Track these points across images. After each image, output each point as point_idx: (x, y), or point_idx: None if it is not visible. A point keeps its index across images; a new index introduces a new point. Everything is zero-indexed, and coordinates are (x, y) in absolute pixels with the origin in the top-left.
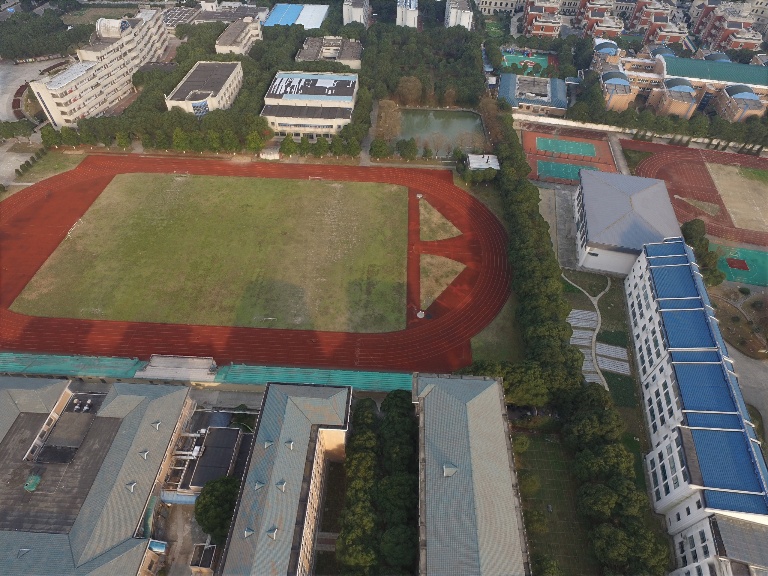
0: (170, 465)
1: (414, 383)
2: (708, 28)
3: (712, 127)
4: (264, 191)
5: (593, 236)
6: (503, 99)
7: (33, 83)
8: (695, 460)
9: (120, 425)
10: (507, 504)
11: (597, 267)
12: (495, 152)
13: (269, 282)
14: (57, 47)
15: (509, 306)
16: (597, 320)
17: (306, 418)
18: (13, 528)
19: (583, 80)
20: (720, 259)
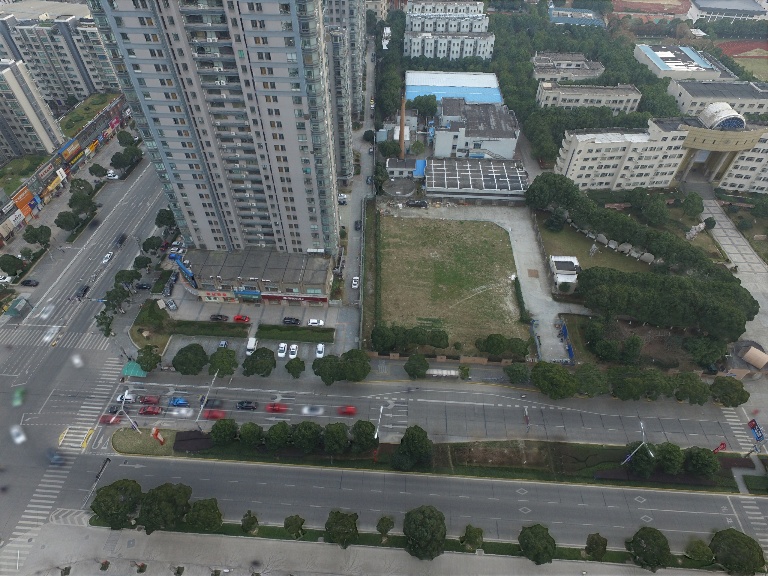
0: None
1: None
2: None
3: None
4: None
5: (763, 10)
6: None
7: None
8: None
9: None
10: None
11: None
12: None
13: None
14: None
15: None
16: None
17: None
18: None
19: (560, 1)
20: None
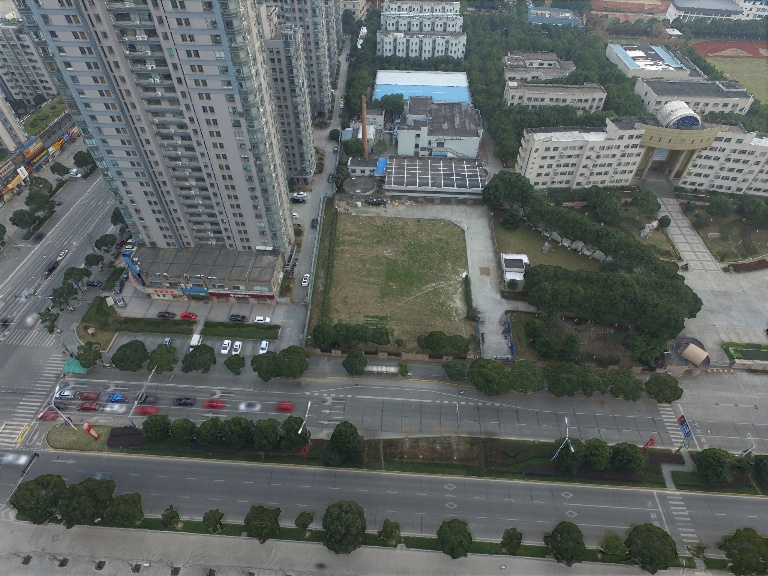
0: None
1: None
2: None
3: None
4: (763, 95)
5: (739, 9)
6: (593, 17)
7: None
8: None
9: None
10: None
11: None
12: None
13: None
14: None
15: None
16: None
17: None
18: None
19: (539, 0)
20: None
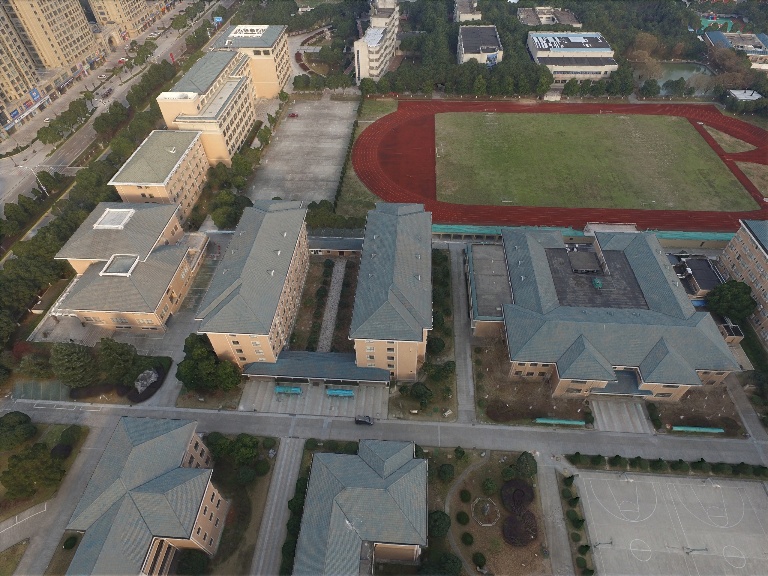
0: None
1: None
2: None
3: None
4: (567, 122)
5: None
6: (733, 49)
7: (357, 42)
8: None
9: (625, 254)
10: None
11: None
12: (754, 87)
13: (626, 181)
14: (309, 23)
15: None
16: None
17: None
18: (606, 307)
19: None
20: None
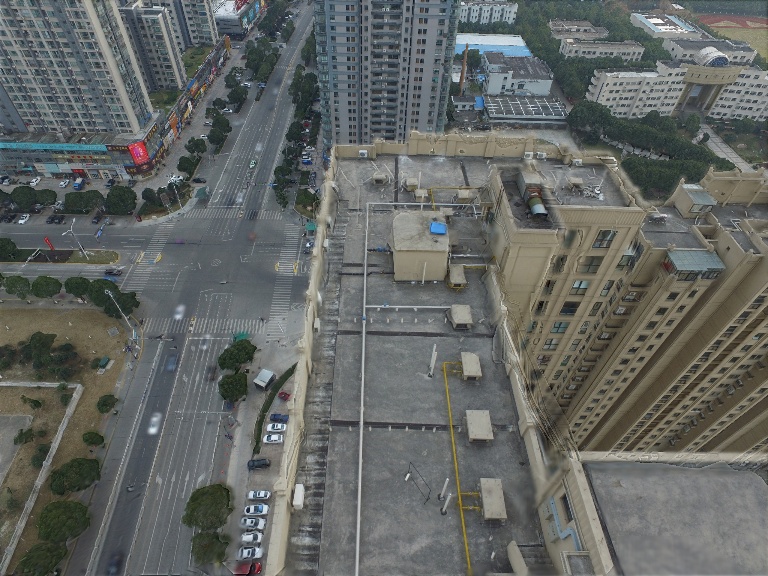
0: None
1: None
2: None
3: None
4: None
5: None
6: None
7: None
8: None
9: None
10: None
11: None
12: None
13: None
14: None
15: (759, 17)
16: None
17: None
18: None
19: None
20: None
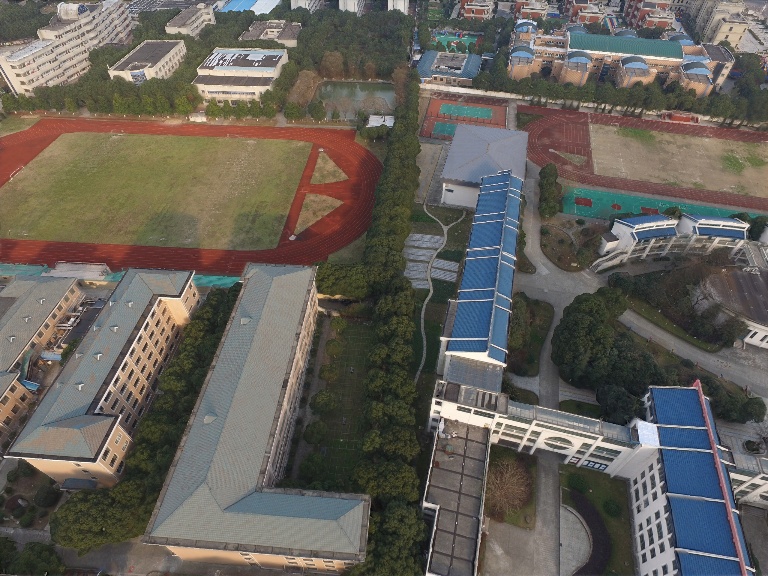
0: (53, 334)
1: (245, 269)
2: (632, 10)
3: (598, 92)
4: (186, 146)
5: (446, 173)
6: (414, 70)
7: None
8: (452, 322)
9: (14, 302)
10: (285, 344)
11: (456, 203)
12: (393, 113)
13: (171, 214)
14: (30, 32)
15: None
16: (442, 242)
17: (149, 289)
18: None
19: (496, 55)
20: (569, 198)
